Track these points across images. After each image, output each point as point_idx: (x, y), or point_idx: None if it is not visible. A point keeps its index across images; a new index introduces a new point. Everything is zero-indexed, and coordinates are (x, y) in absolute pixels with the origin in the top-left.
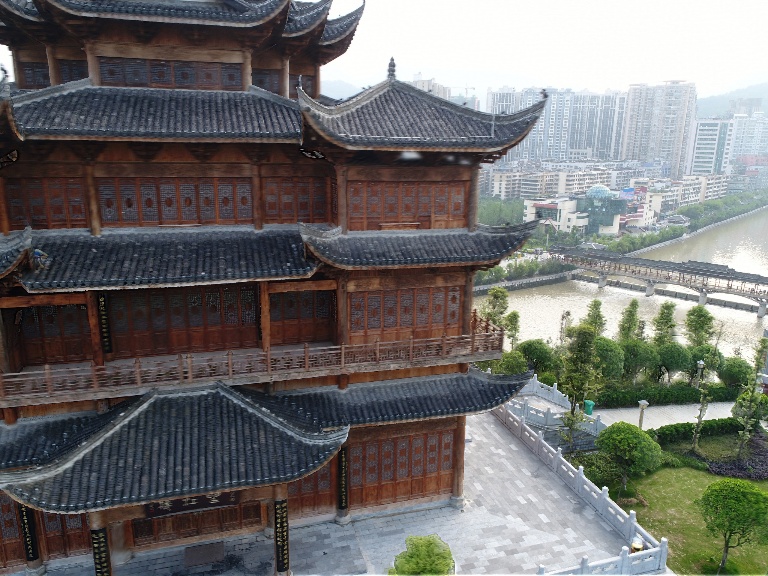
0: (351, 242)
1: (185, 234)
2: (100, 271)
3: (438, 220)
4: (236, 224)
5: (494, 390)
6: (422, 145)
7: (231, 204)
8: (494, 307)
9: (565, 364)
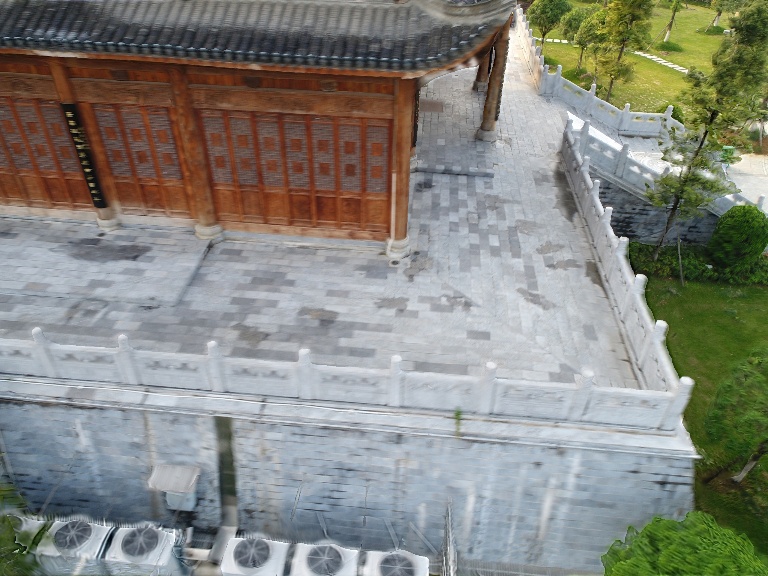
0: None
1: None
2: None
3: None
4: None
5: None
6: None
7: None
8: None
9: None
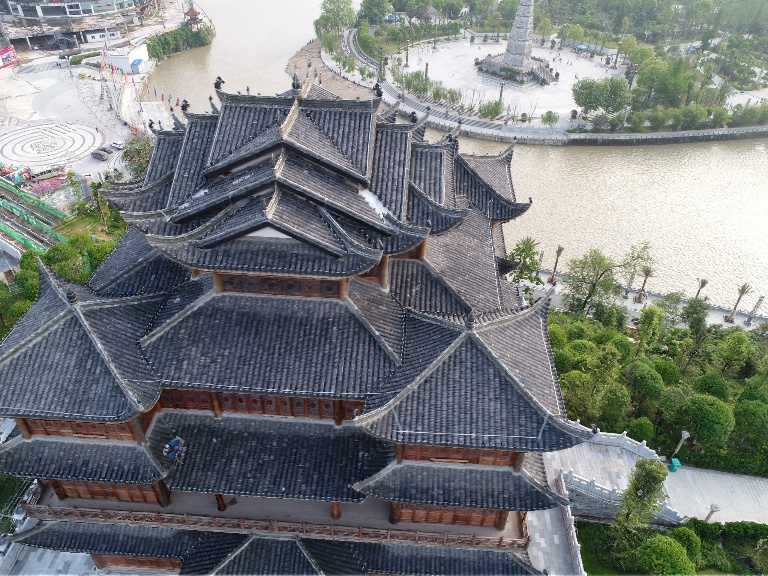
0: (403, 473)
1: (281, 424)
2: (215, 473)
3: (486, 460)
4: (321, 418)
5: (515, 568)
6: (465, 446)
7: (317, 407)
8: (602, 363)
9: (629, 485)
